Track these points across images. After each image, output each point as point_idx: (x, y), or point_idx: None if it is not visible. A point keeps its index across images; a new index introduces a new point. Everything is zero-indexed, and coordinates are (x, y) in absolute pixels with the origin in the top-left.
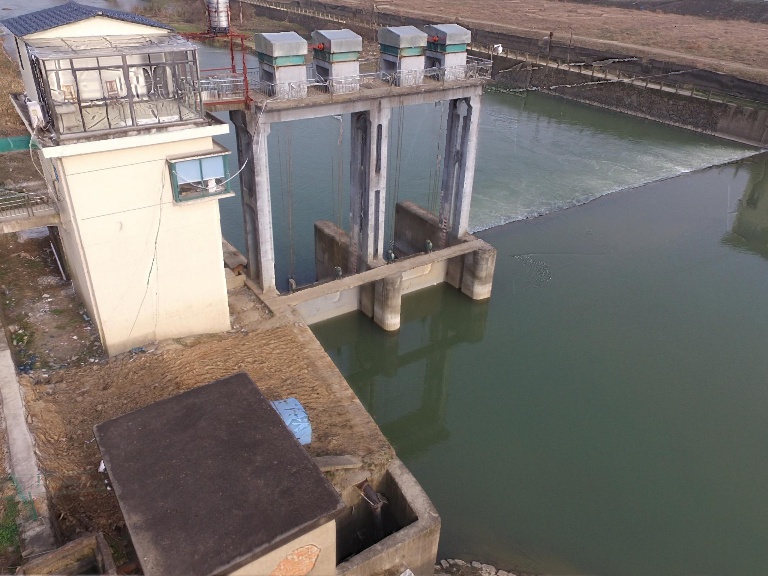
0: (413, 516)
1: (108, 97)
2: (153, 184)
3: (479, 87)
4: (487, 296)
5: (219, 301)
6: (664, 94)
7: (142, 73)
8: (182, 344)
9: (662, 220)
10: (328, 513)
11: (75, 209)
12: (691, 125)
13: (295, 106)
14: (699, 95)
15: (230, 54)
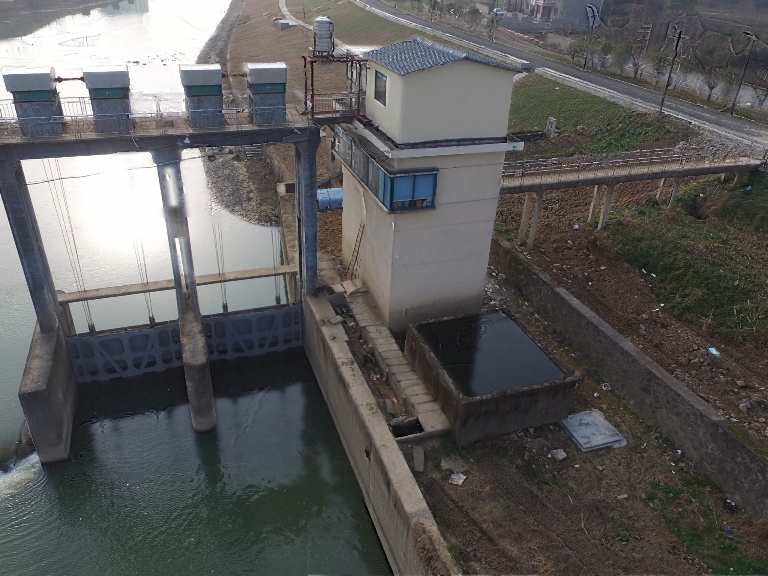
0: None
1: None
2: None
3: None
4: None
5: None
6: None
7: None
8: None
9: None
10: None
11: None
12: None
13: None
14: None
15: None
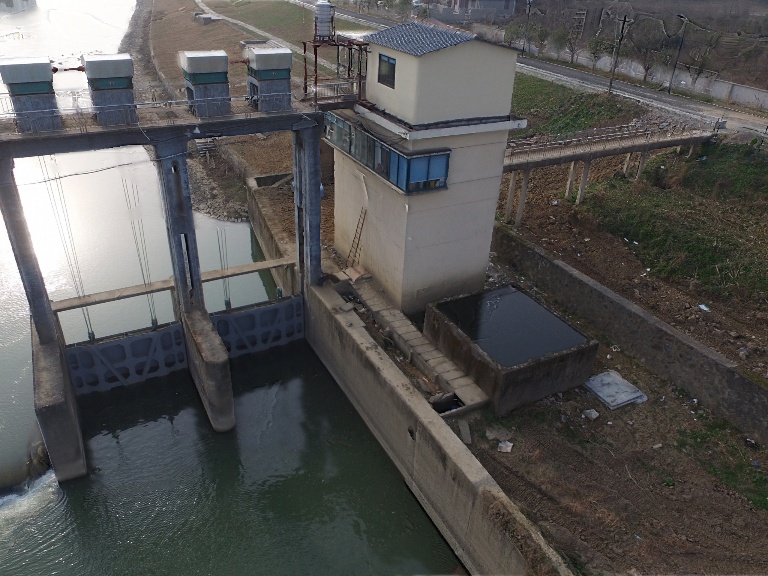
0: None
1: None
2: None
3: None
4: None
5: None
6: None
7: None
8: None
9: None
10: None
11: None
12: None
13: None
14: None
15: None
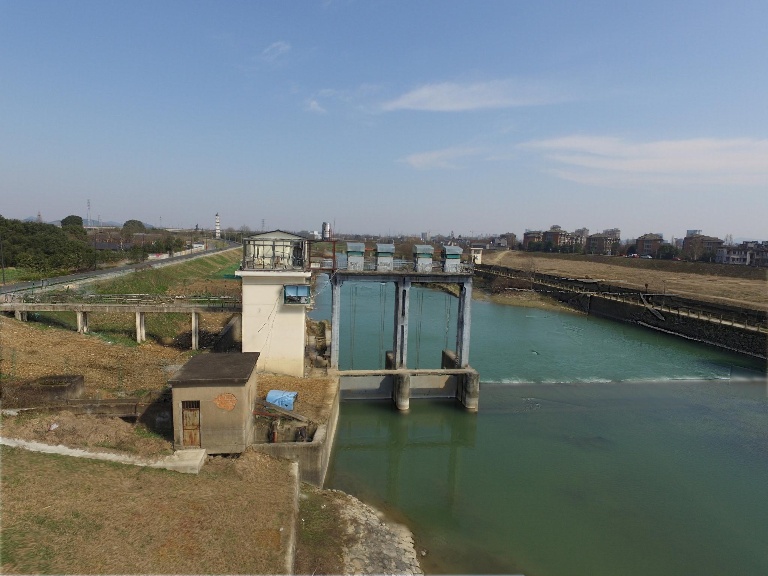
0: None
1: (275, 262)
2: (276, 294)
3: (470, 278)
4: (475, 407)
5: (299, 359)
6: (735, 329)
7: None
8: (275, 375)
9: (664, 400)
10: (239, 378)
11: (243, 299)
12: (761, 354)
13: None
14: (765, 331)
15: (432, 291)
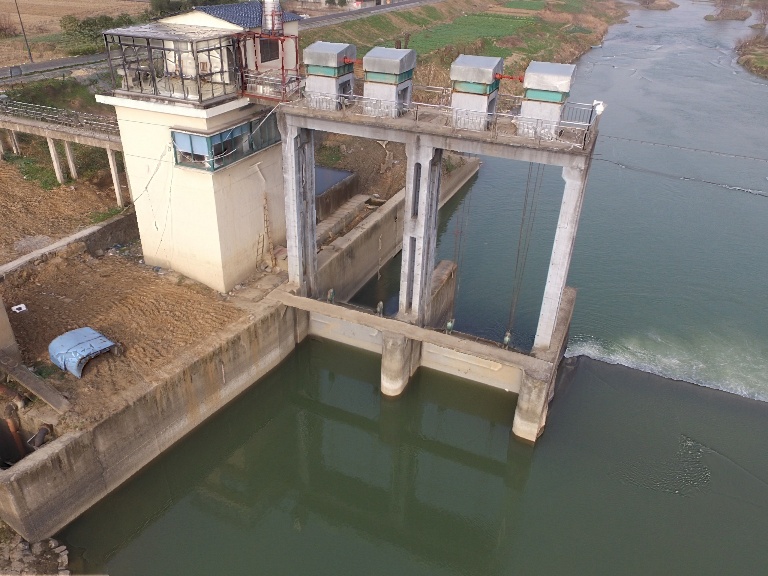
0: None
1: None
2: None
3: (580, 157)
4: (530, 438)
5: (216, 263)
6: None
7: (227, 61)
8: (181, 281)
9: None
10: None
11: (123, 145)
12: None
13: (304, 115)
14: None
15: None
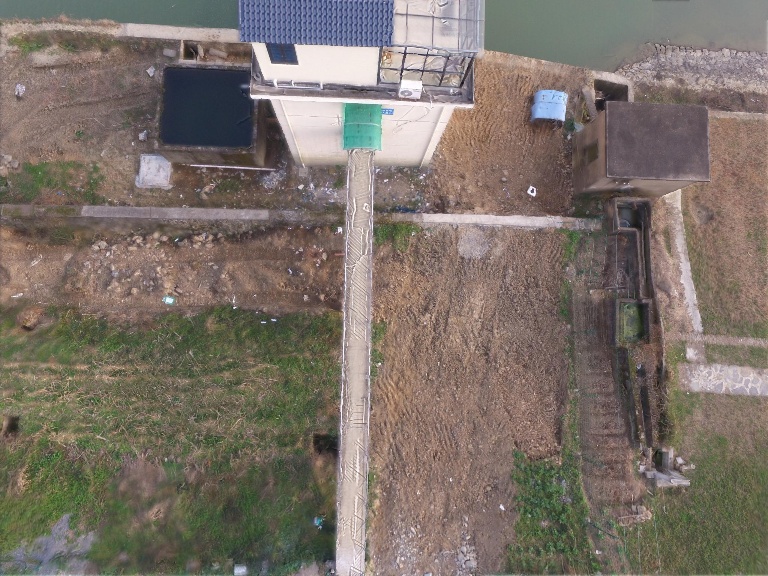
0: (624, 87)
1: None
2: None
3: None
4: None
5: None
6: None
7: None
8: None
9: None
10: None
11: None
12: None
13: None
14: None
15: None
